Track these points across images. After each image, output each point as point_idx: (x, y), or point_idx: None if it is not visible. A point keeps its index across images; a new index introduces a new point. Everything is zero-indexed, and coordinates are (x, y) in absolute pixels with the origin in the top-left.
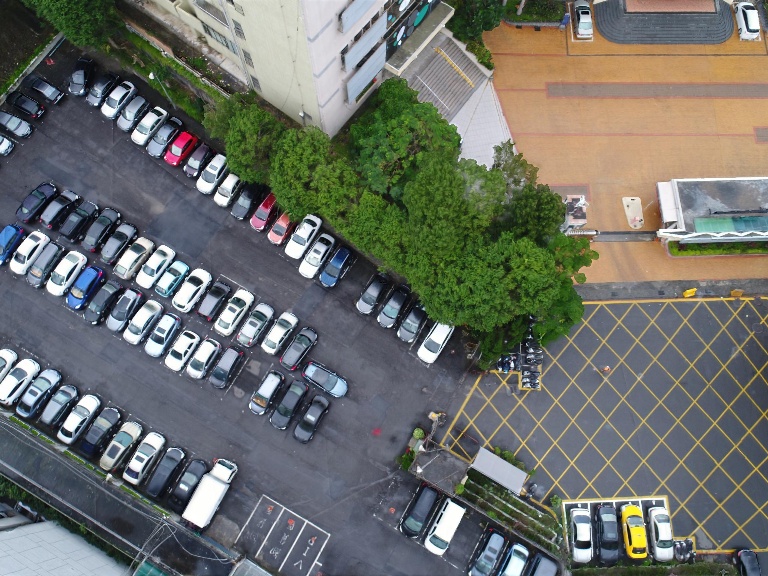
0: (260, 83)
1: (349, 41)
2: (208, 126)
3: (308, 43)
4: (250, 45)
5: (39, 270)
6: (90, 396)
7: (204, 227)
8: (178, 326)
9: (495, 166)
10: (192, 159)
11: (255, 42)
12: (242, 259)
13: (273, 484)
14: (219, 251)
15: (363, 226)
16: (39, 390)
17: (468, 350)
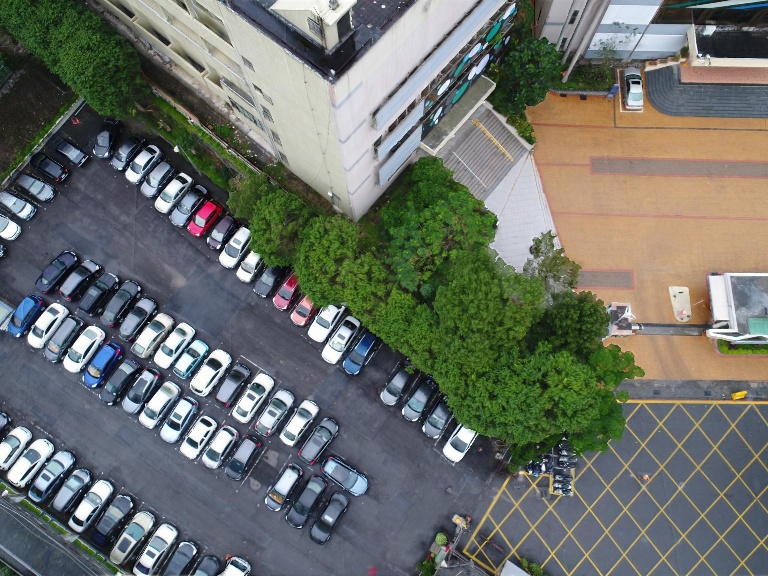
0: (288, 159)
1: (383, 132)
2: (232, 207)
3: (339, 143)
4: (278, 128)
5: (56, 346)
6: (103, 482)
7: (225, 303)
8: (195, 410)
9: (533, 257)
10: (216, 231)
11: (284, 127)
12: (263, 340)
13: None
14: (240, 330)
15: (391, 326)
16: (52, 474)
17: (497, 448)
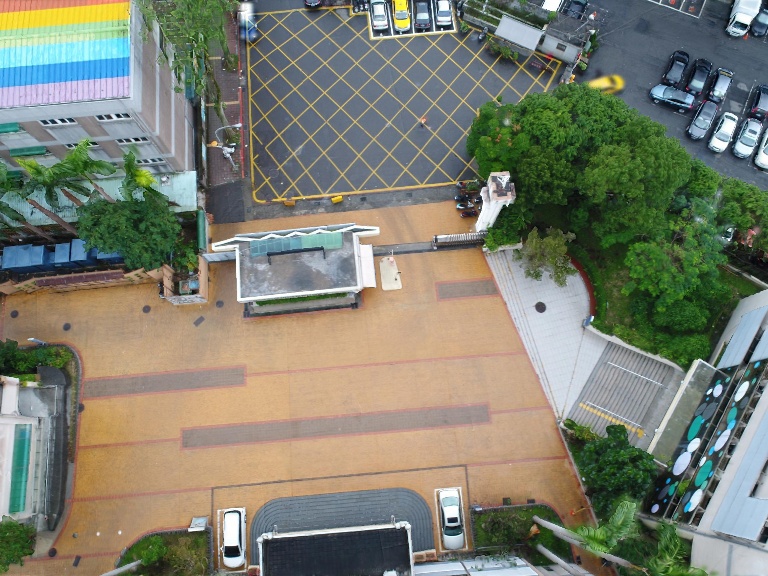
0: None
1: None
2: None
3: None
4: None
5: None
6: None
7: None
8: None
9: None
10: None
11: None
12: None
13: (693, 25)
14: None
15: None
16: None
17: None
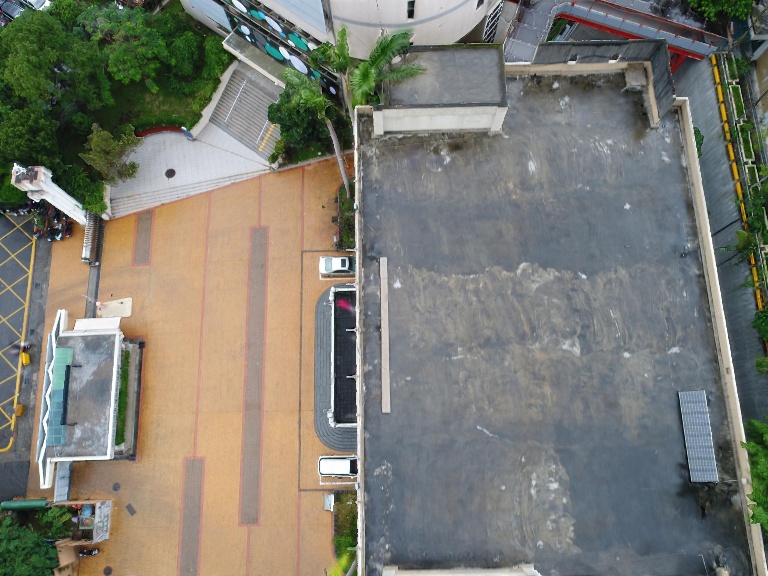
0: None
1: None
2: None
3: None
4: None
5: None
6: None
7: None
8: None
9: None
10: None
11: None
12: None
13: None
14: None
15: None
16: None
17: None
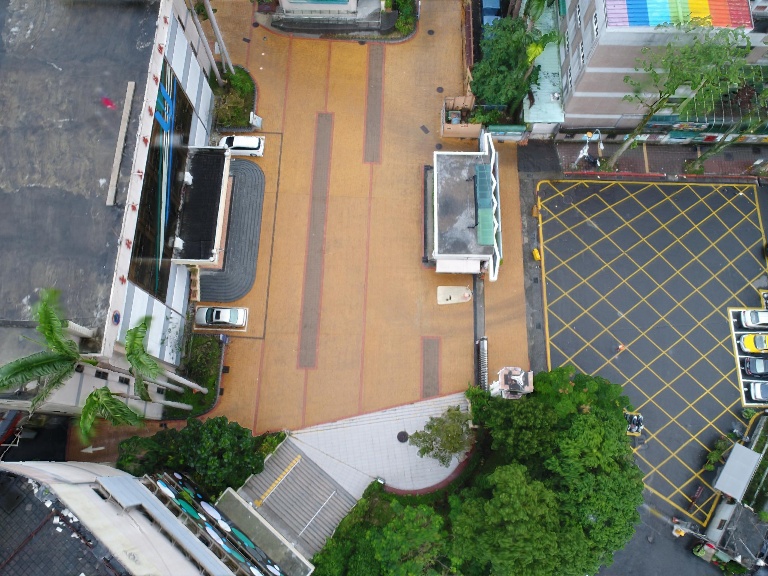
0: None
1: None
2: None
3: None
4: None
5: None
6: None
7: None
8: None
9: None
10: None
11: None
12: None
13: None
14: None
15: None
16: None
17: None
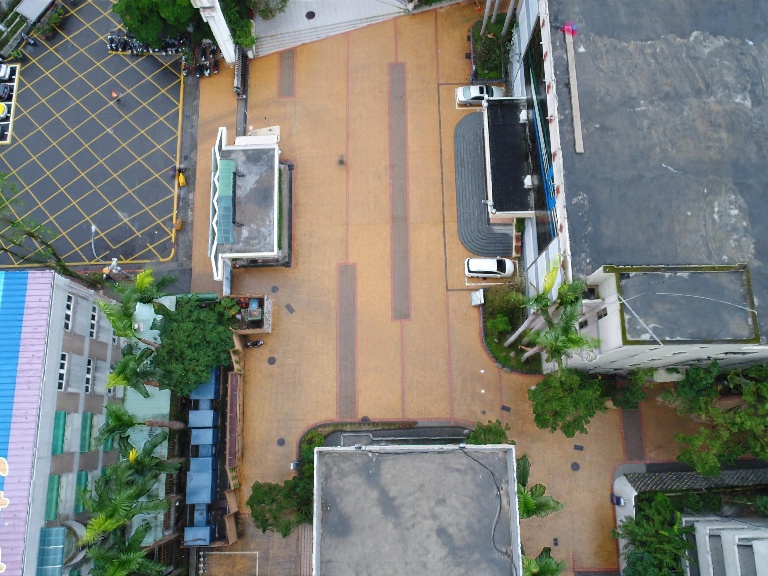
0: None
1: None
2: None
3: None
4: None
5: None
6: None
7: None
8: None
9: None
10: None
11: None
12: None
13: None
14: None
15: None
16: None
17: None
